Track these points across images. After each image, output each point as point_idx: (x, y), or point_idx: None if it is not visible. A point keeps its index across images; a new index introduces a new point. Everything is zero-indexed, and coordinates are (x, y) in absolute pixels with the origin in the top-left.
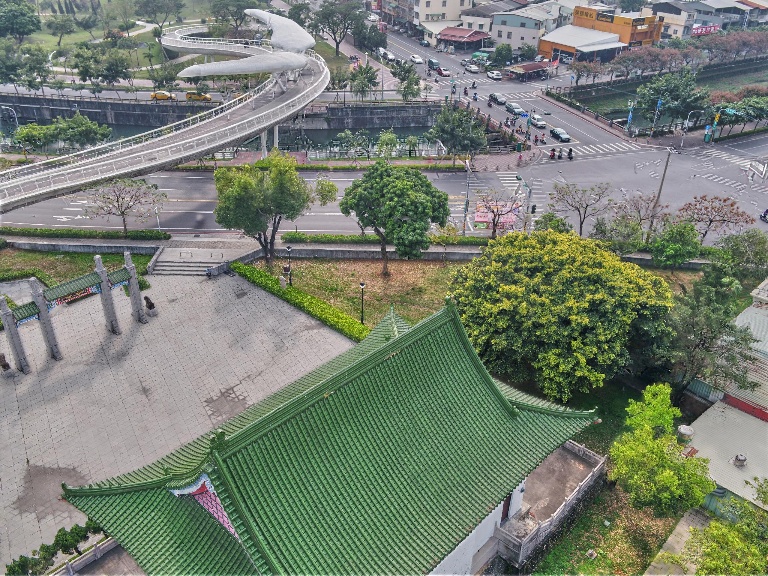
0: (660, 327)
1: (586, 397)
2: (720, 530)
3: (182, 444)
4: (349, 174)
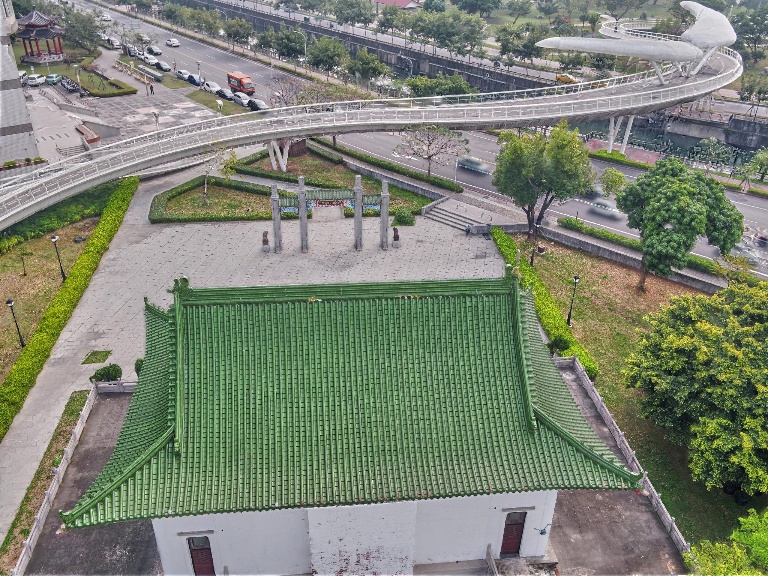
0: None
1: None
2: None
3: None
4: None
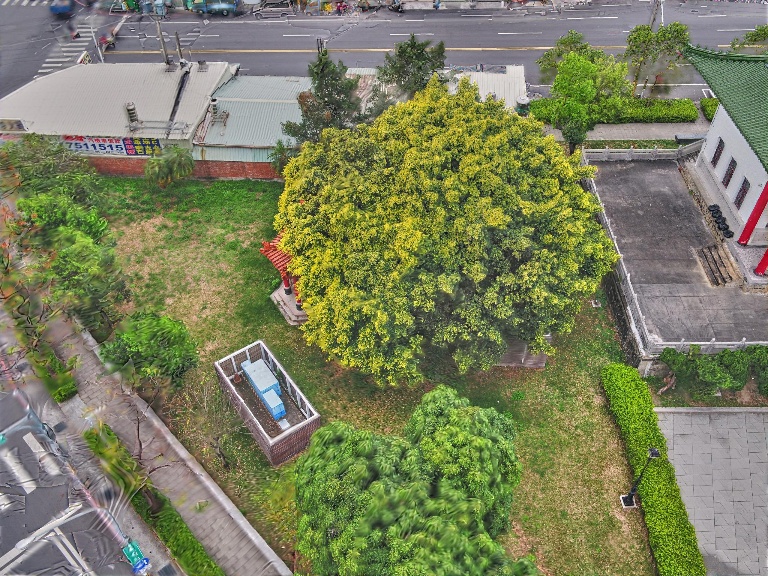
0: None
1: None
2: None
3: None
4: None
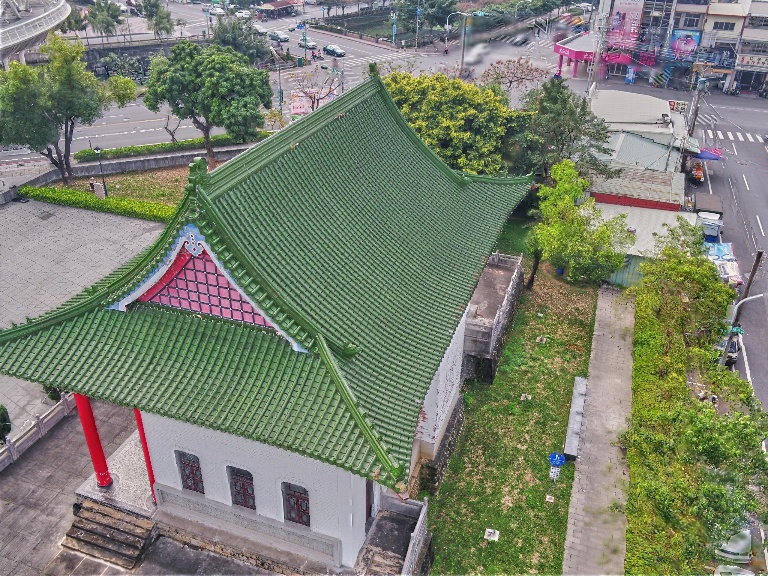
0: (529, 136)
1: None
2: None
3: None
4: None
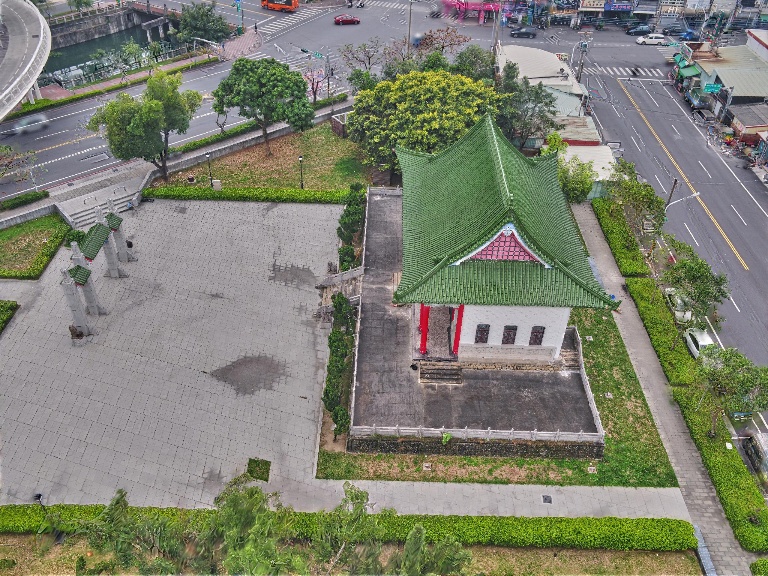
0: (510, 110)
1: None
2: None
3: (294, 307)
4: None
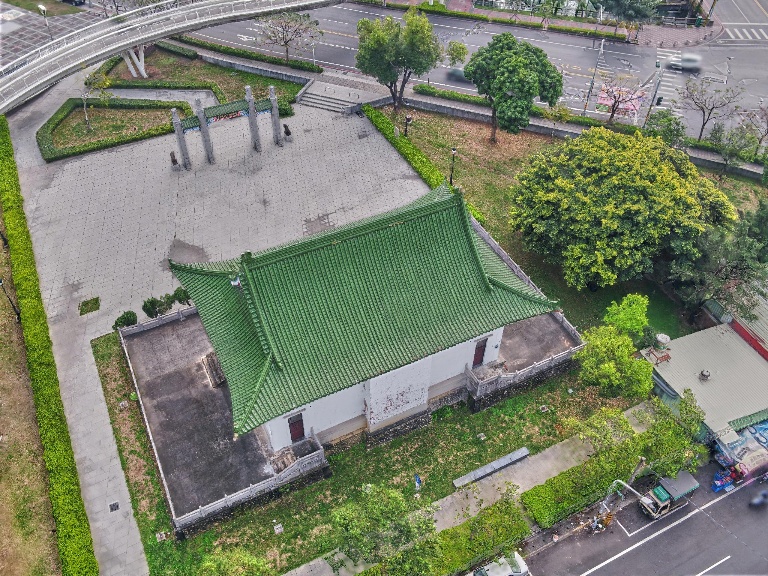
0: (686, 247)
1: (615, 291)
2: (618, 415)
3: None
4: (505, 29)
